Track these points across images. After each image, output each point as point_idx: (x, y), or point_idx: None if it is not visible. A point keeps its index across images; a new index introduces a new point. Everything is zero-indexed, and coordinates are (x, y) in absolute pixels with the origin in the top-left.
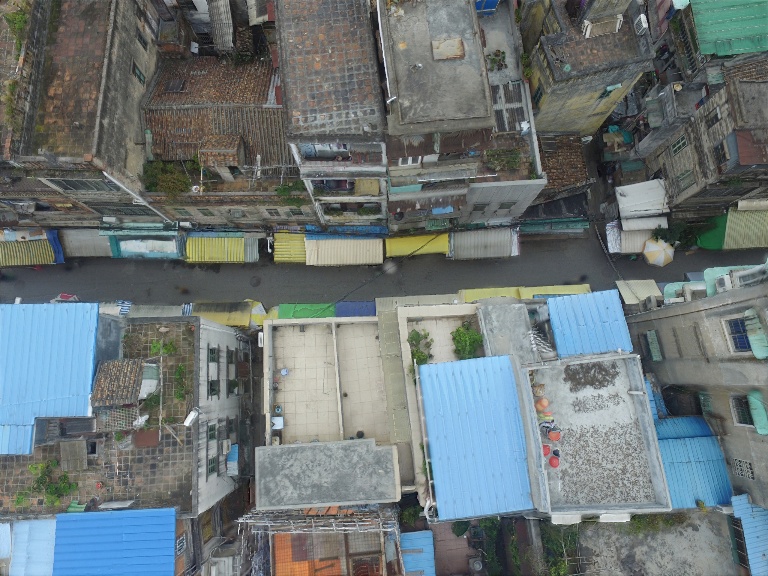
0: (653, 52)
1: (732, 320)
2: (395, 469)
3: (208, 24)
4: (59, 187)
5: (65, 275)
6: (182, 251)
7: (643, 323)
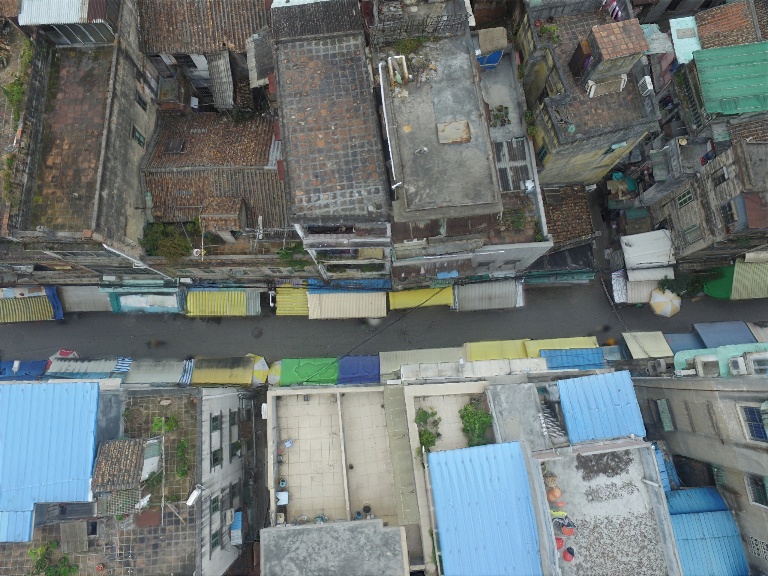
0: (658, 113)
1: (747, 407)
2: (403, 552)
3: (208, 80)
4: (58, 254)
5: (64, 328)
6: (183, 305)
7: (653, 389)
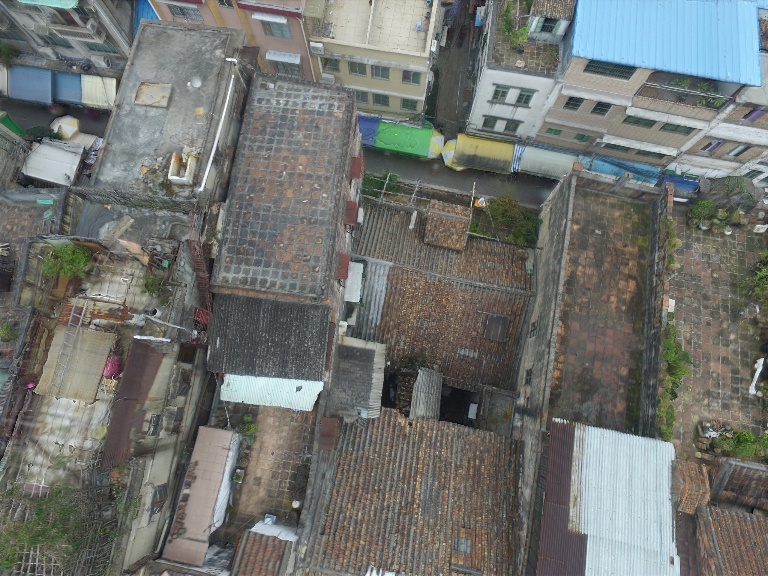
0: None
1: None
2: None
3: None
4: None
5: None
6: None
7: (107, 5)
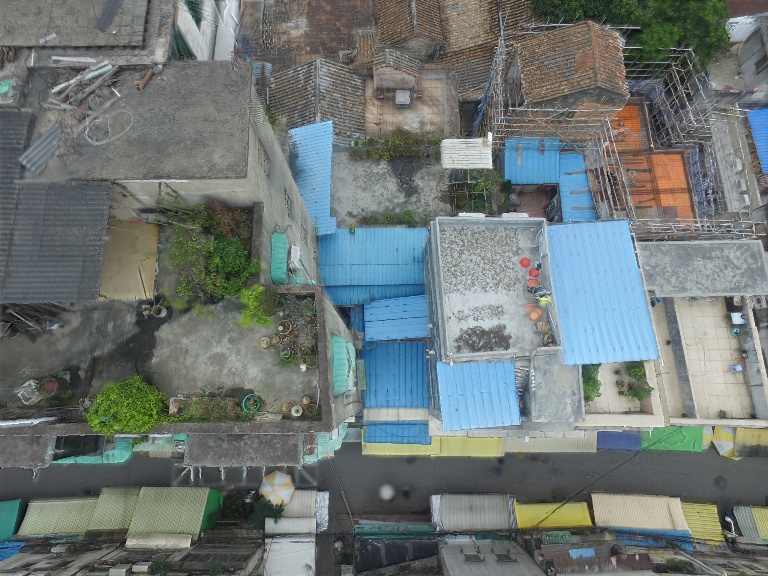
0: None
1: None
2: None
3: None
4: None
5: None
6: None
7: None
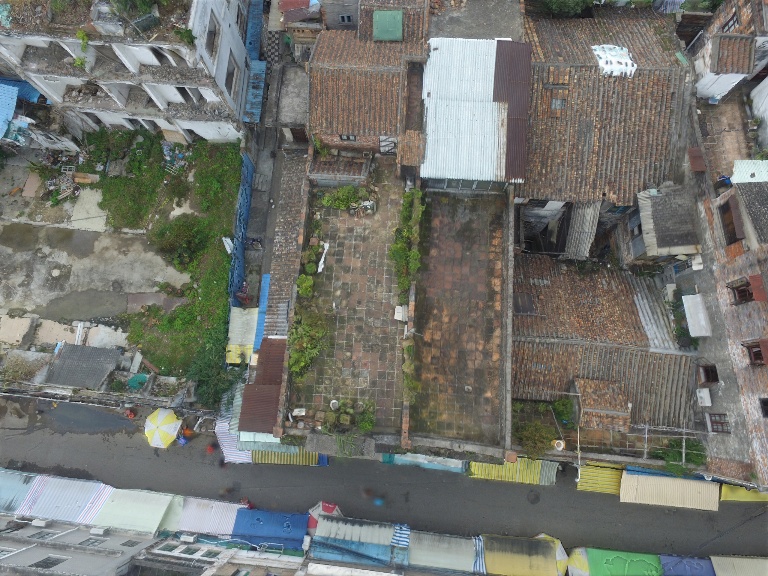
0: None
1: None
2: None
3: (542, 217)
4: None
5: None
6: None
7: None
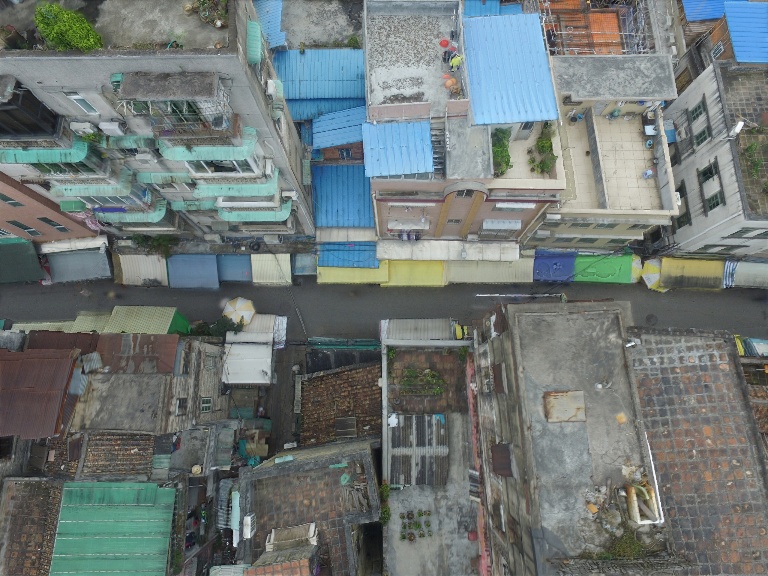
0: (243, 483)
1: None
2: None
3: None
4: None
5: None
6: (746, 346)
7: None
